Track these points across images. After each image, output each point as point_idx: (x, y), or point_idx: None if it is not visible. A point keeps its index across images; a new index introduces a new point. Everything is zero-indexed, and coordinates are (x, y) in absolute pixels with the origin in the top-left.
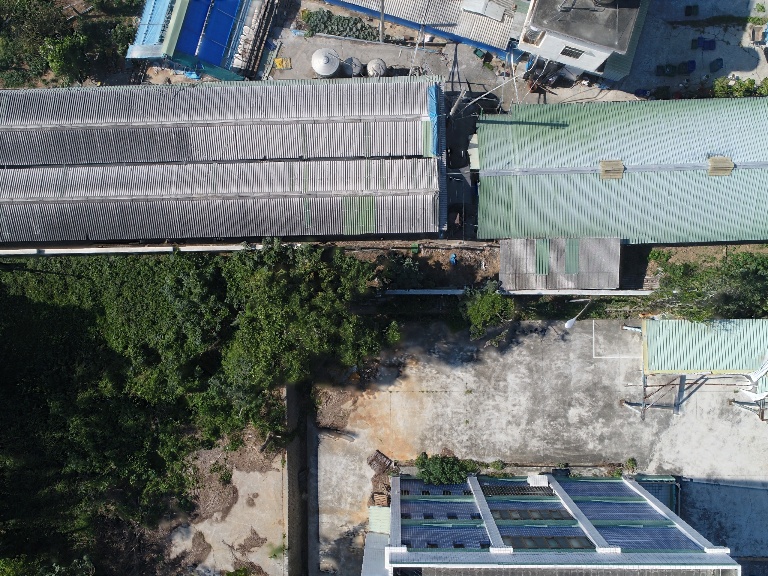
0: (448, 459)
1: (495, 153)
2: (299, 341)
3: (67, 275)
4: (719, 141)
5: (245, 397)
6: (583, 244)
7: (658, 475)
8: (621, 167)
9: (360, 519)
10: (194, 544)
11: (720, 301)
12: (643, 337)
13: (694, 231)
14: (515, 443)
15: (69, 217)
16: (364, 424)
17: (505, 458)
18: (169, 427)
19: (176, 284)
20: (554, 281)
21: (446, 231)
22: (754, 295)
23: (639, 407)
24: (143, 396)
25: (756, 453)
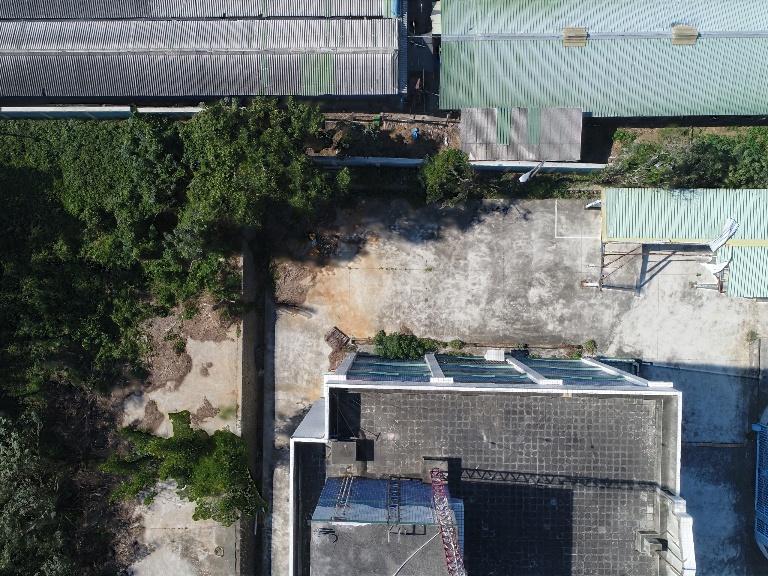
0: (406, 337)
1: (458, 19)
2: (248, 184)
3: (25, 137)
4: (684, 11)
5: (194, 243)
6: (545, 114)
7: (618, 358)
8: (584, 33)
9: (316, 397)
10: (147, 413)
11: (681, 171)
12: (602, 205)
13: (658, 104)
14: (474, 323)
15: (25, 71)
16: (322, 300)
17: (464, 338)
18: (123, 292)
19: (133, 144)
20: (515, 152)
21: (409, 104)
22: (715, 164)
23: None
24: (98, 260)
25: (717, 338)
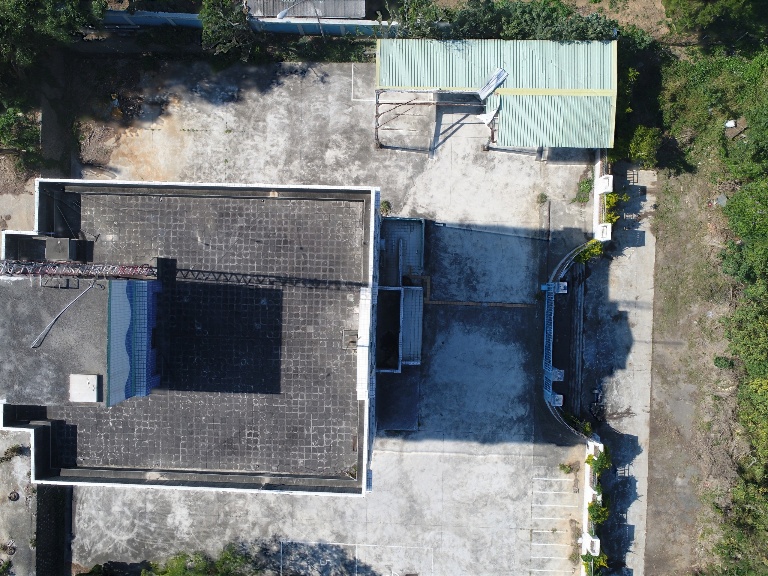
0: None
1: None
2: (7, 13)
3: None
4: None
5: None
6: None
7: None
8: None
9: None
10: None
11: (455, 23)
12: (376, 55)
13: None
14: None
15: None
16: (126, 161)
17: None
18: None
19: None
20: (301, 8)
21: None
22: (486, 15)
23: (395, 150)
24: None
25: (509, 200)
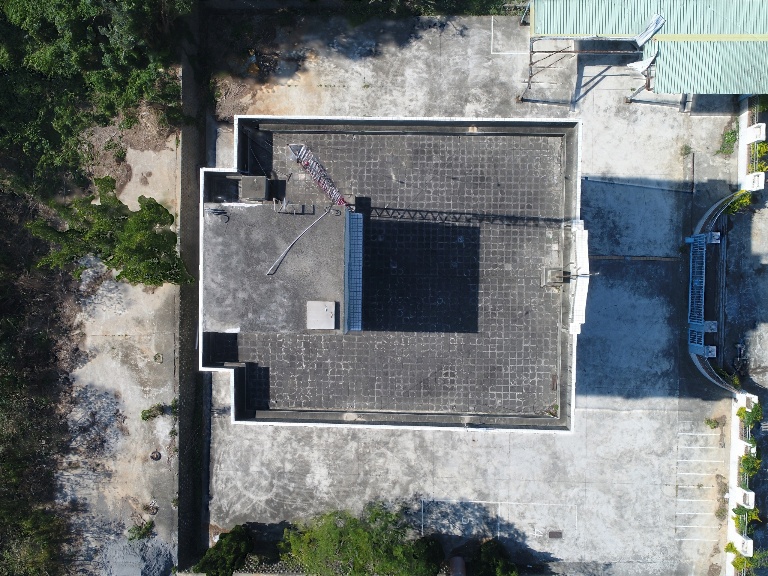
0: None
1: None
2: None
3: None
4: None
5: (123, 23)
6: None
7: None
8: None
9: None
10: None
11: None
12: (530, 2)
13: None
14: None
15: None
16: None
17: None
18: (64, 99)
19: None
20: None
21: None
22: None
23: (536, 104)
24: (39, 68)
25: (652, 152)
